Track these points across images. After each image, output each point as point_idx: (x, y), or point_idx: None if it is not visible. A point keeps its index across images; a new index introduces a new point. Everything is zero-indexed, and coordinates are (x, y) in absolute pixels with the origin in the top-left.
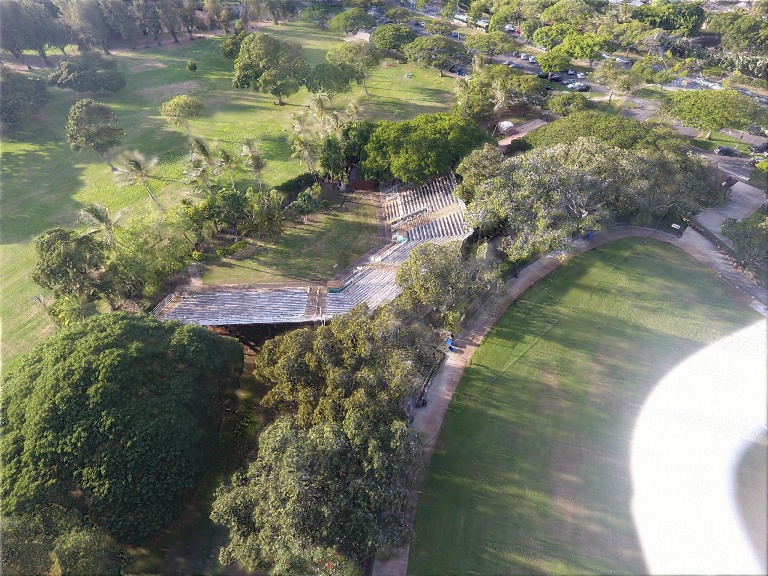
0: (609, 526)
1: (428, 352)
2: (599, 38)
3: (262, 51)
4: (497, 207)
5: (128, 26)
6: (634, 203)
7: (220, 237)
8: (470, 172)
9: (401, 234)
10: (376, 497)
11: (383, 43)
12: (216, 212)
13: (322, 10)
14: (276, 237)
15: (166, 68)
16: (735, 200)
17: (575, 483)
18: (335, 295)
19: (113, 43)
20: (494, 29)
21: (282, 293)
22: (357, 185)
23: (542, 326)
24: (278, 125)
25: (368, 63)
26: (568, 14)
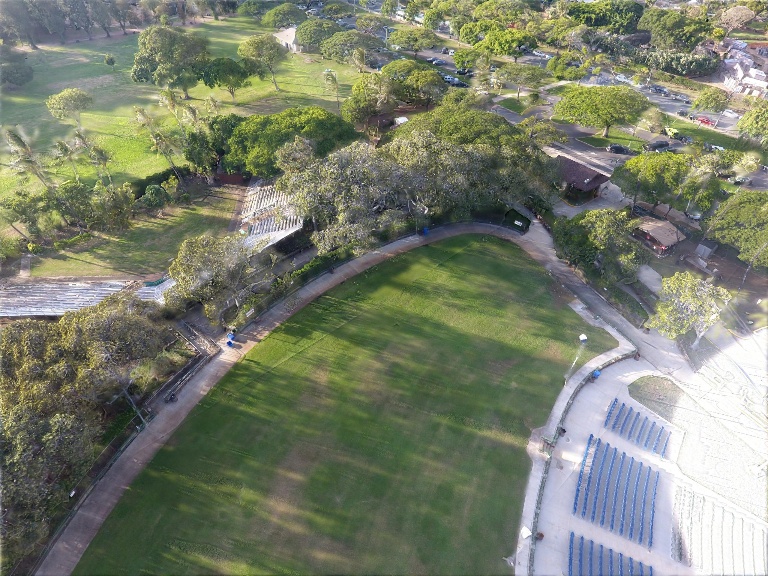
0: (315, 526)
1: (139, 345)
2: (519, 34)
3: (157, 45)
4: (302, 201)
5: (53, 20)
6: (453, 198)
7: (68, 230)
8: (287, 165)
9: (243, 228)
10: (5, 491)
11: (304, 38)
12: (54, 204)
13: (257, 5)
14: (124, 230)
15: (88, 62)
16: (607, 198)
17: (299, 482)
18: (148, 288)
19: (44, 37)
20: (426, 25)
21: (97, 286)
22: (227, 179)
23: (336, 322)
24: (175, 119)
25: (271, 58)
26: (499, 10)
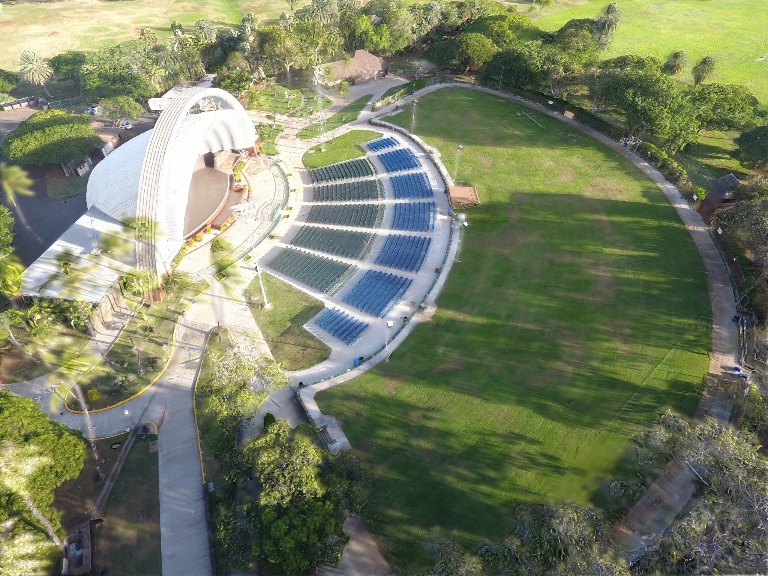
0: (576, 265)
1: None
2: None
3: None
4: None
5: None
6: None
7: None
8: None
9: None
10: None
11: None
12: None
13: None
14: None
15: None
16: None
17: (598, 282)
18: None
19: None
20: None
21: None
22: None
23: (641, 399)
24: None
25: None
26: None
